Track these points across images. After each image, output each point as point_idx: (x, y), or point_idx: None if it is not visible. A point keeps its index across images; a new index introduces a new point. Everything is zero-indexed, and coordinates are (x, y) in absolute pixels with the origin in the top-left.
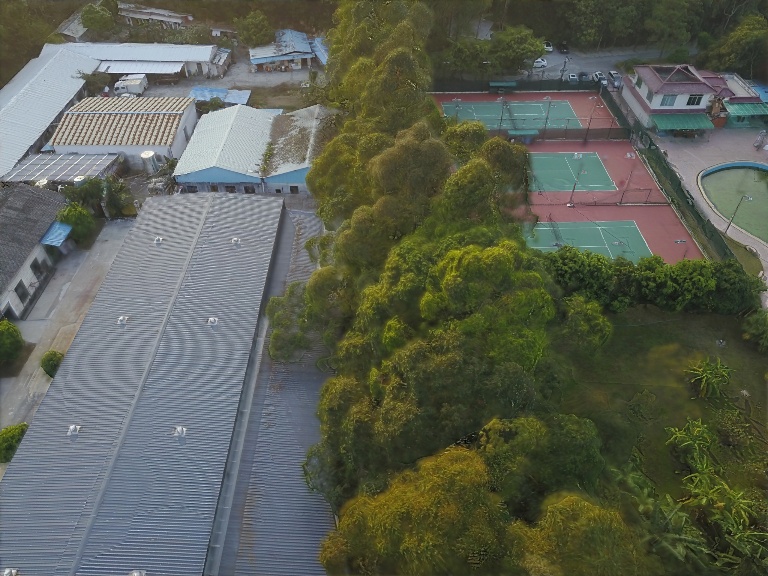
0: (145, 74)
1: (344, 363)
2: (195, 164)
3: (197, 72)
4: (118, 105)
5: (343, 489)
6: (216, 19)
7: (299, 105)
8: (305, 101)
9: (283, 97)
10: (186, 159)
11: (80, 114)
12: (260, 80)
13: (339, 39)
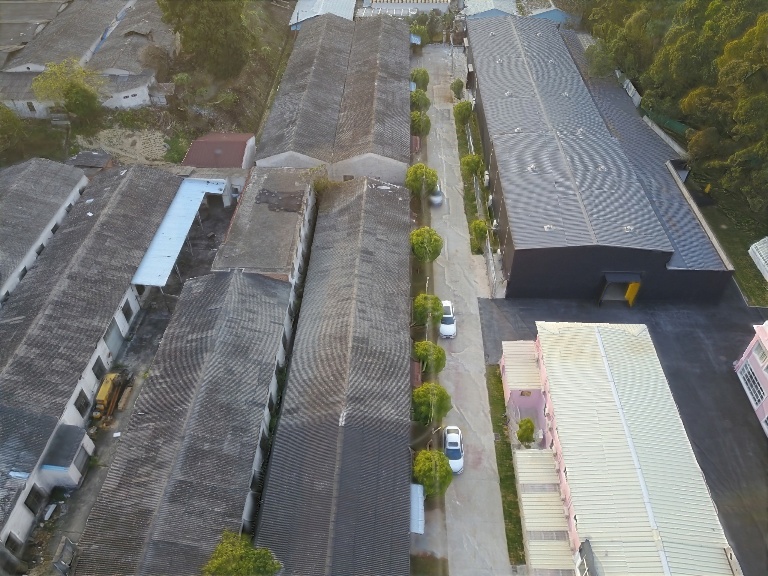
0: None
1: (671, 41)
2: (478, 9)
3: None
4: None
5: (669, 104)
6: None
7: None
8: None
9: None
10: (468, 9)
11: None
12: None
13: None
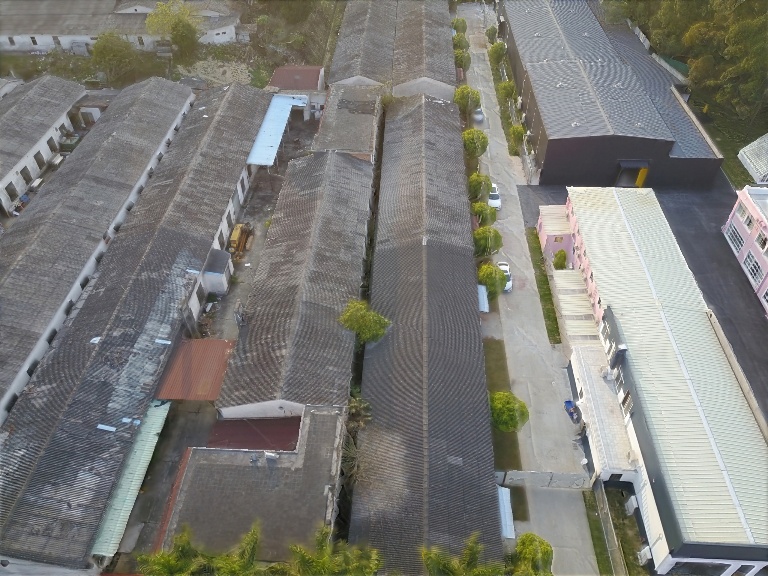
0: None
1: None
2: None
3: None
4: None
5: (674, 41)
6: None
7: None
8: None
9: None
10: None
11: None
12: None
13: None
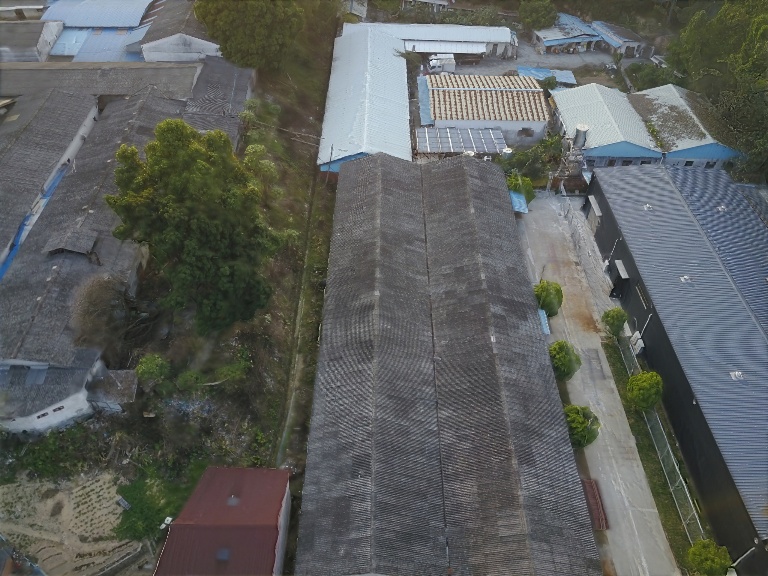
0: (453, 54)
1: None
2: (596, 139)
3: (491, 53)
4: (470, 82)
5: None
6: (476, 2)
7: (613, 86)
8: (618, 82)
9: (591, 78)
10: None
11: (445, 90)
12: (555, 61)
13: (766, 19)
